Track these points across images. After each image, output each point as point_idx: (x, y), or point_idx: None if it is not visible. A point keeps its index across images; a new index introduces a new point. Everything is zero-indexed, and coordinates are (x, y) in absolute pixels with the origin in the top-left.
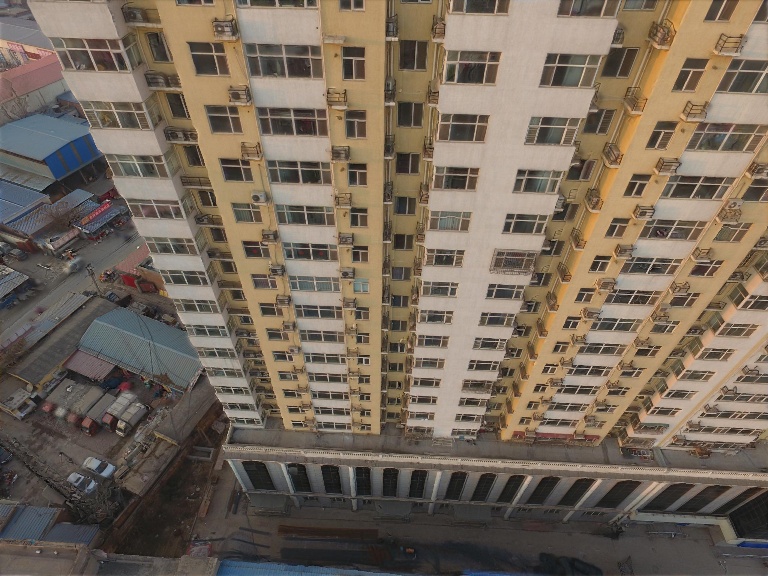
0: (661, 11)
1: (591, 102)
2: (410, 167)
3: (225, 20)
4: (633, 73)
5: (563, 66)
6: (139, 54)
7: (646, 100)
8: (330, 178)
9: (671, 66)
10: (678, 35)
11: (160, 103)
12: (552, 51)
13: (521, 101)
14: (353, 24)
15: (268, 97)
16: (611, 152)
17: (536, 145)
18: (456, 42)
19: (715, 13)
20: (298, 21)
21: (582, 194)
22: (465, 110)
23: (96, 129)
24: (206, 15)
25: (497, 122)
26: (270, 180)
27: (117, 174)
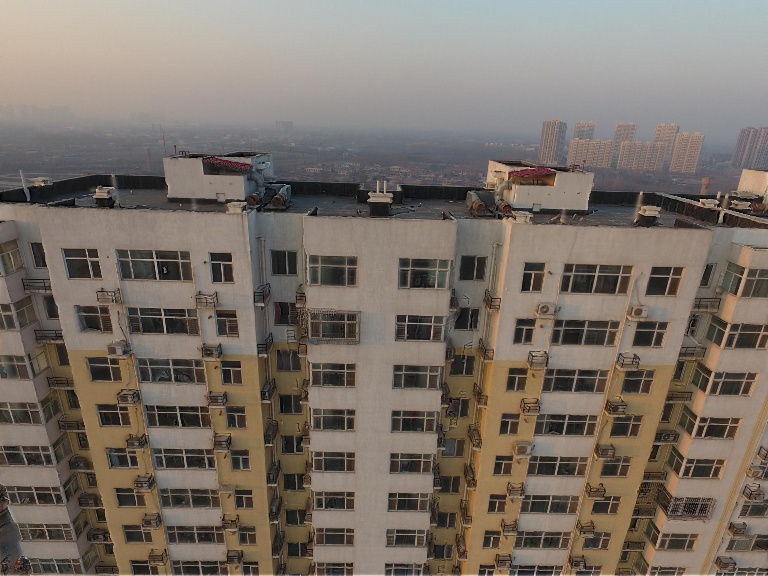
0: (468, 459)
1: (430, 519)
2: (300, 552)
3: (145, 476)
4: (461, 491)
5: (403, 499)
6: (77, 484)
7: (471, 518)
8: (227, 571)
9: (481, 499)
10: (479, 482)
11: (88, 513)
12: (392, 491)
13: (376, 520)
14: (242, 478)
15: (175, 519)
16: (459, 546)
17: (395, 547)
18: (320, 487)
19: (499, 470)
20: (201, 476)
21: (449, 569)
22: (334, 526)
23: (26, 542)
24: (131, 473)
25: (361, 533)
26: (174, 574)
27: (36, 572)
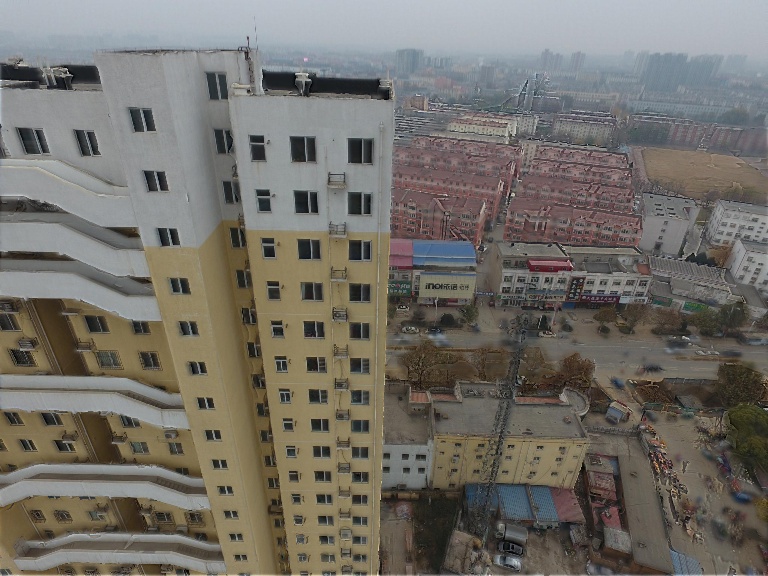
0: None
1: None
2: None
3: None
4: None
5: None
6: None
7: None
8: None
9: None
10: None
11: None
12: None
13: None
14: None
15: None
16: None
17: None
18: None
19: None
20: None
21: None
22: None
23: None
24: None
25: None
26: None
27: None
